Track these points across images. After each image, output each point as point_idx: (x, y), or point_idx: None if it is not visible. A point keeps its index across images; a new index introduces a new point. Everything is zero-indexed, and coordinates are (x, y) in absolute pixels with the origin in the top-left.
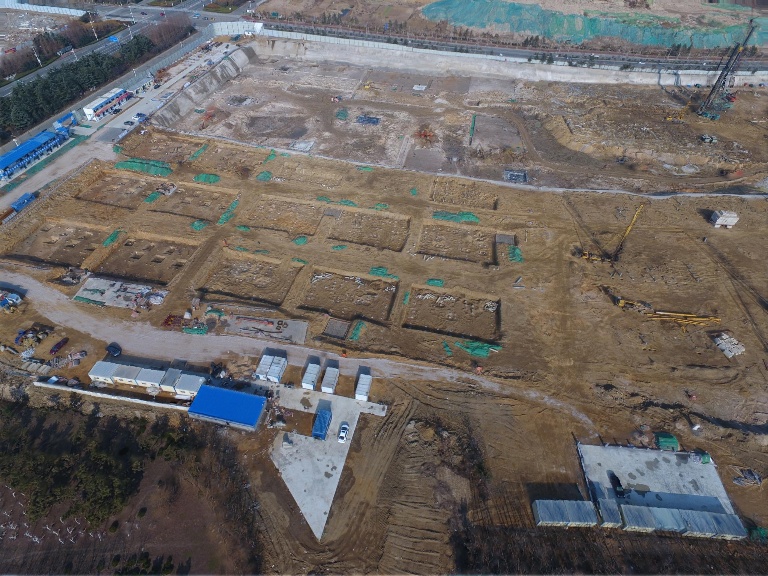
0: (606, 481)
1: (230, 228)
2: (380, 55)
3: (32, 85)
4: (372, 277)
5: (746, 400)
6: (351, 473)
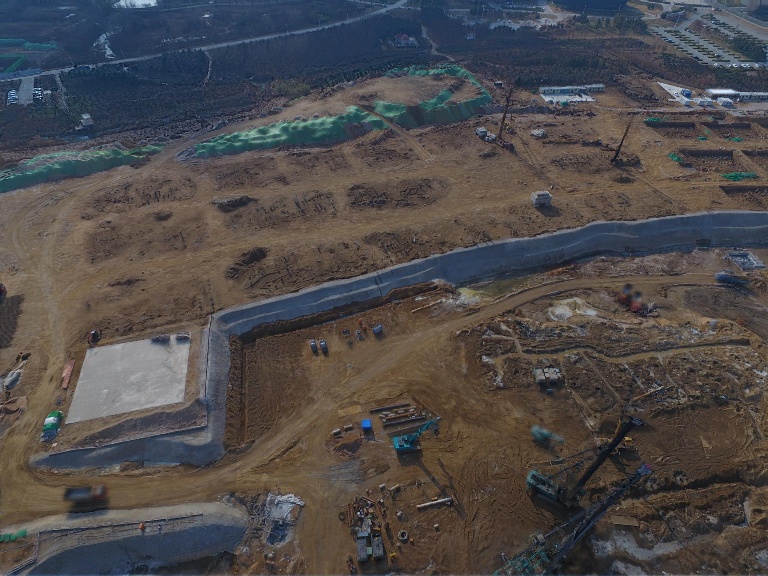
0: None
1: None
2: None
3: None
4: None
5: (531, 119)
6: None
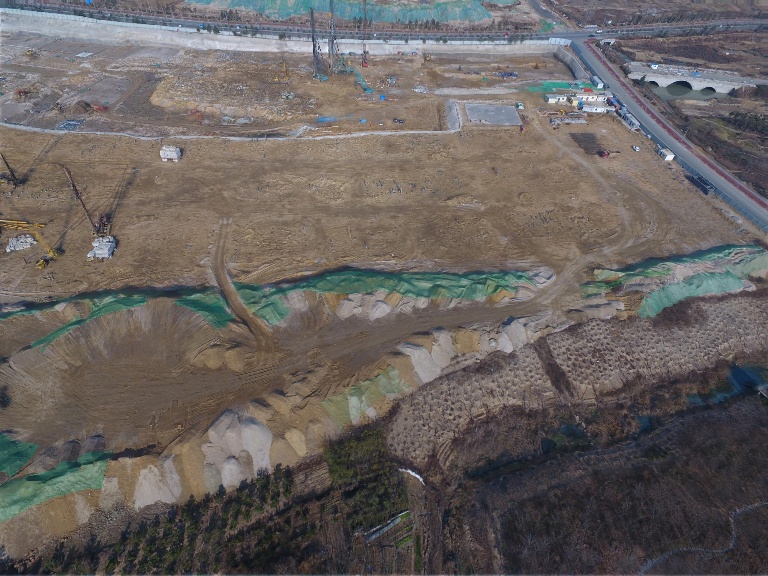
0: None
1: None
2: (68, 26)
3: None
4: None
5: None
6: None
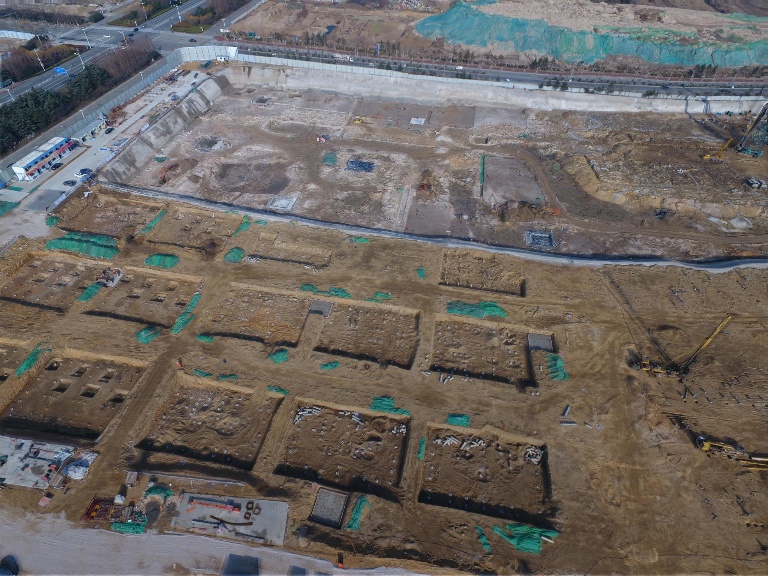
0: None
1: (188, 338)
2: (371, 82)
3: None
4: (374, 412)
5: None
6: None
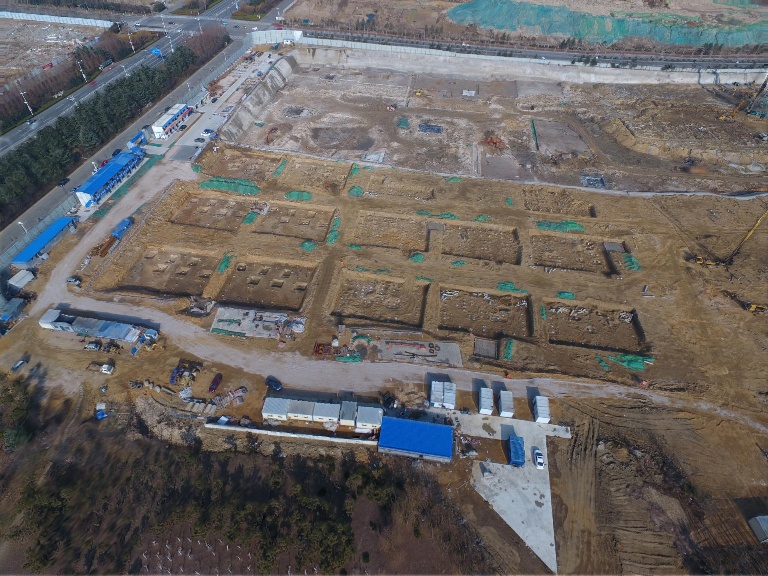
0: None
1: (341, 247)
2: (423, 61)
3: (93, 103)
4: (501, 292)
5: None
6: (561, 500)
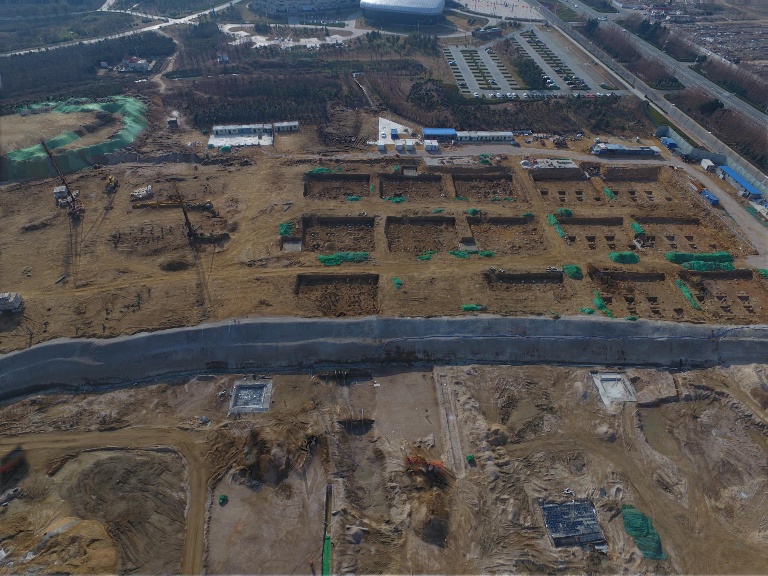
0: (264, 137)
1: (538, 213)
2: None
3: None
4: None
5: (162, 170)
6: (375, 128)
